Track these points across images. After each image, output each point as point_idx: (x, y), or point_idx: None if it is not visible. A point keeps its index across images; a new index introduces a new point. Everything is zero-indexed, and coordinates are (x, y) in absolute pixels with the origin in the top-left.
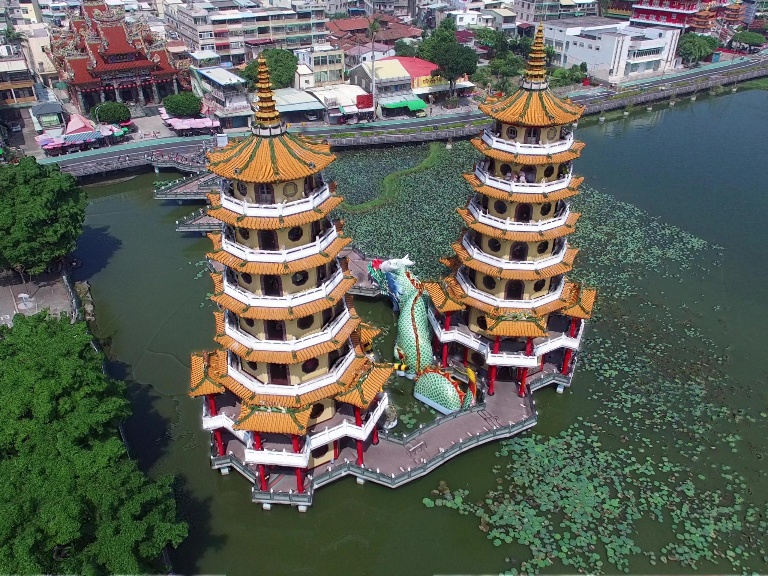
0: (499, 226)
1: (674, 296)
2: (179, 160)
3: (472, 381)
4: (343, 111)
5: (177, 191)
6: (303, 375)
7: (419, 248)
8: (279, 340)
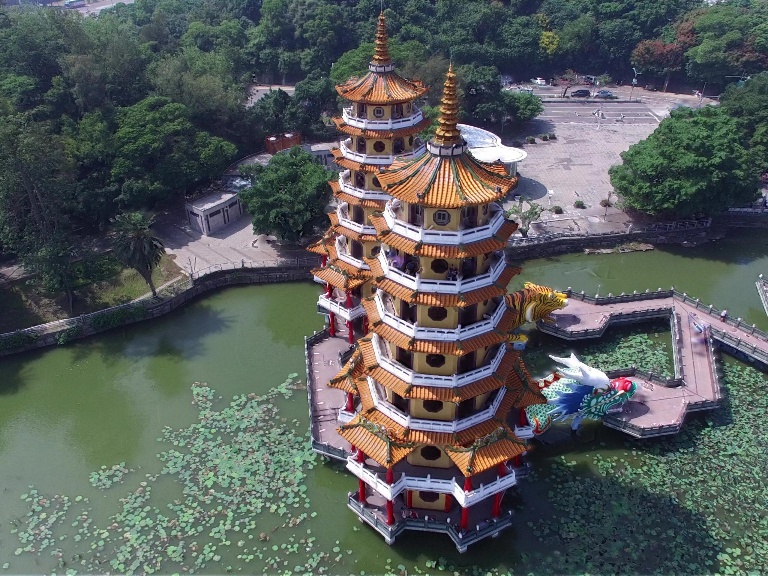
0: None
1: None
2: None
3: None
4: None
5: None
6: None
7: (767, 501)
8: None
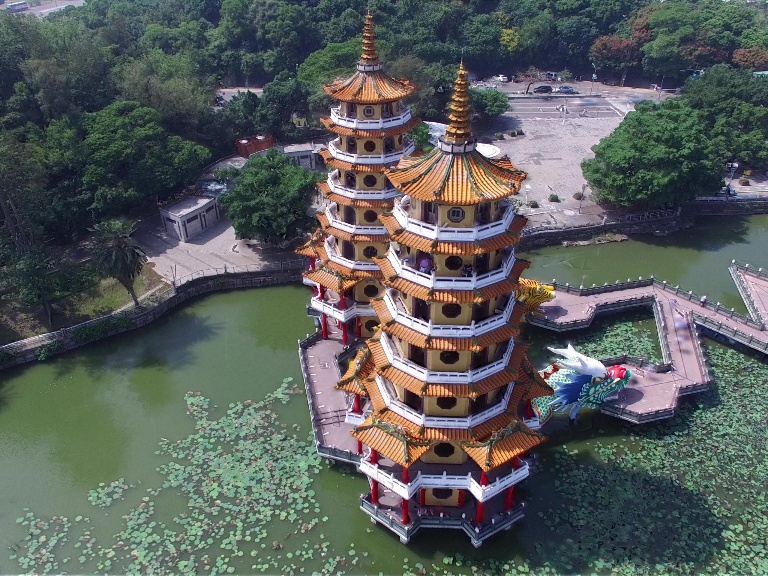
0: None
1: None
2: None
3: None
4: None
5: None
6: None
7: (763, 477)
8: None
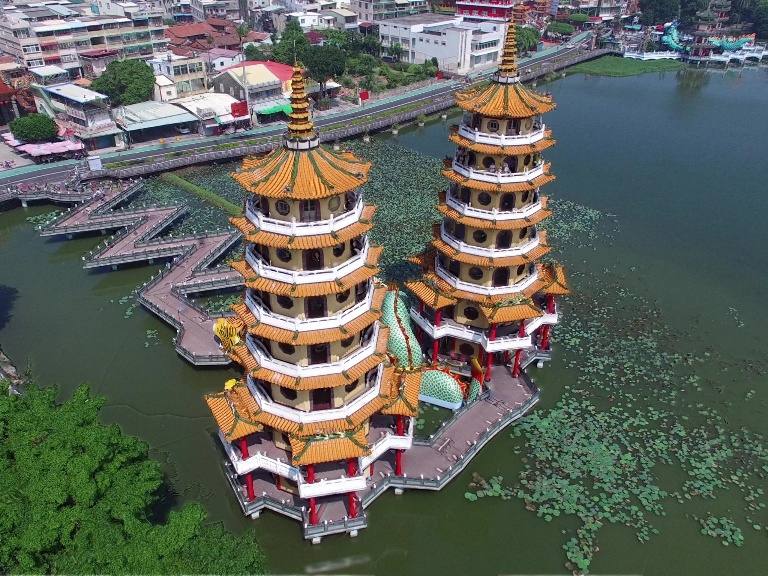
0: (487, 217)
1: (596, 263)
2: (52, 190)
3: (480, 371)
4: (219, 121)
5: (65, 224)
6: (345, 395)
7: None
8: (321, 363)
